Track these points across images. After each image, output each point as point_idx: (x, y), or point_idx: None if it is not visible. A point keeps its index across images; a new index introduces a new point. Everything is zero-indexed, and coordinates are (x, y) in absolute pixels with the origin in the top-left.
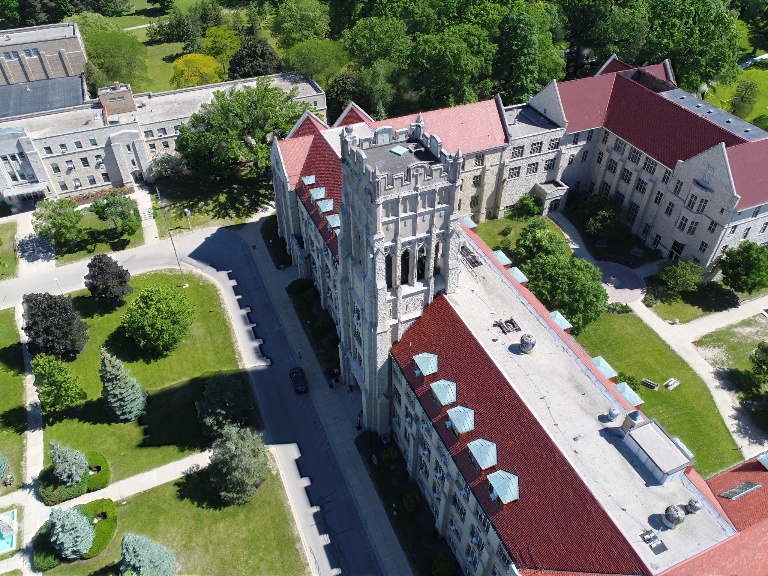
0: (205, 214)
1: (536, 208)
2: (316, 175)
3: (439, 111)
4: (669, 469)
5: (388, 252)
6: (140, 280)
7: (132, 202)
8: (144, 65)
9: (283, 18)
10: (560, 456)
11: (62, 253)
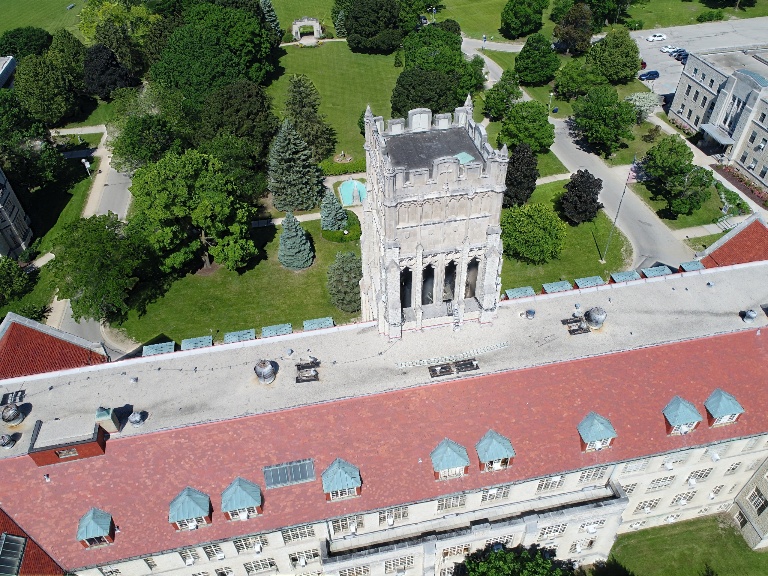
0: None
1: None
2: None
3: None
4: (43, 427)
5: None
6: (610, 232)
7: (741, 209)
8: None
9: None
10: None
11: (647, 183)
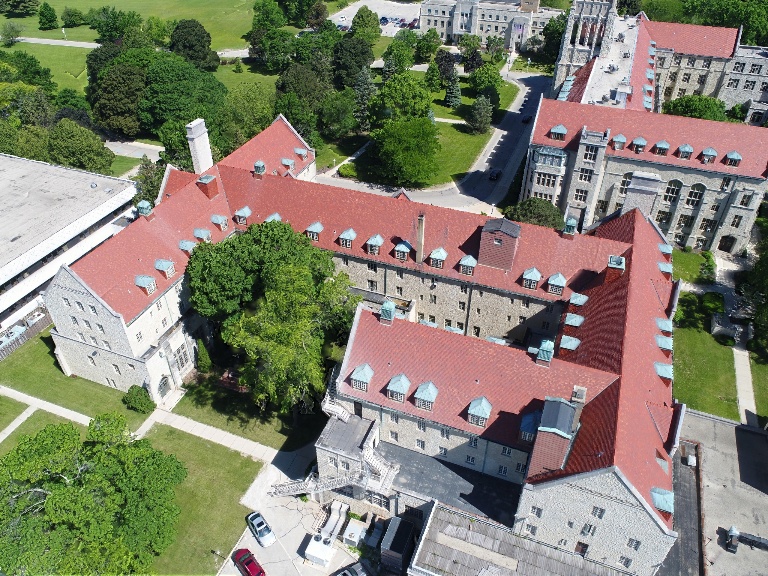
0: (539, 69)
1: (740, 113)
2: None
3: (693, 26)
4: None
5: (576, 20)
6: None
7: (507, 54)
8: (560, 4)
9: None
10: None
11: (462, 63)
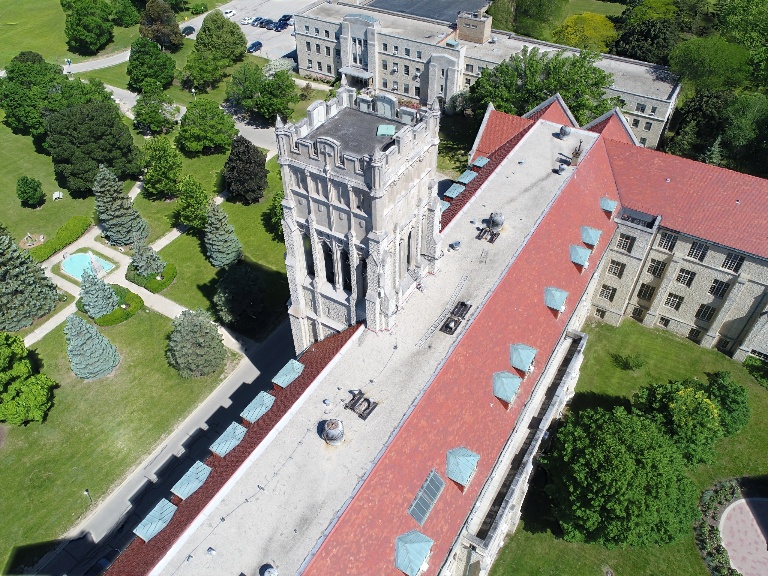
0: (453, 161)
1: None
2: (490, 160)
3: (715, 168)
4: None
5: (304, 231)
6: None
7: None
8: (557, 12)
9: (734, 8)
10: (173, 542)
11: None
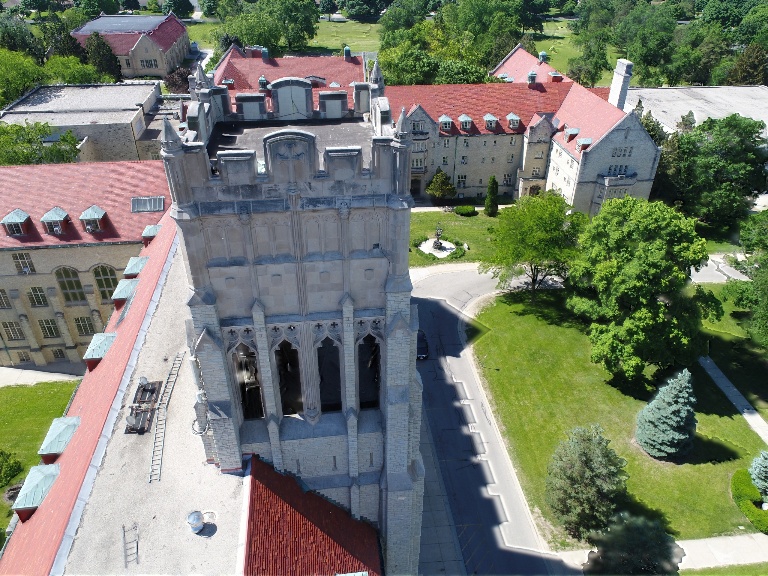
0: None
1: None
2: None
3: None
4: None
5: None
6: None
7: None
8: None
9: None
10: None
11: None
